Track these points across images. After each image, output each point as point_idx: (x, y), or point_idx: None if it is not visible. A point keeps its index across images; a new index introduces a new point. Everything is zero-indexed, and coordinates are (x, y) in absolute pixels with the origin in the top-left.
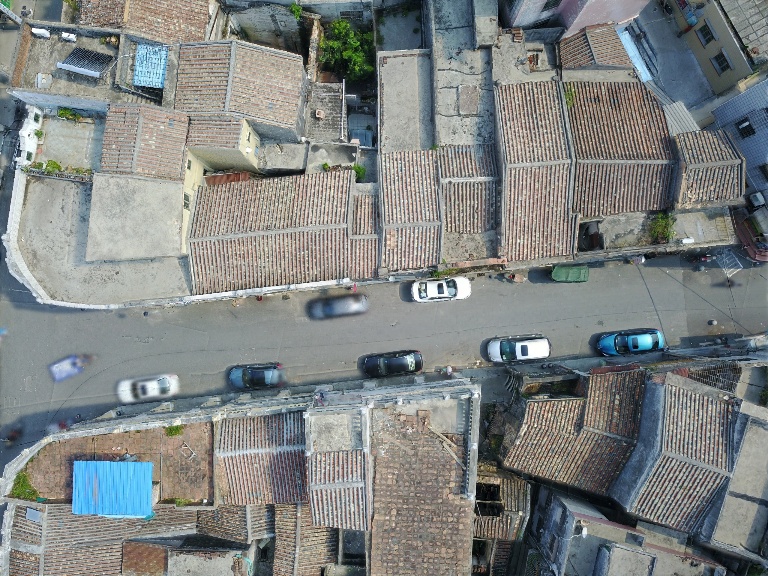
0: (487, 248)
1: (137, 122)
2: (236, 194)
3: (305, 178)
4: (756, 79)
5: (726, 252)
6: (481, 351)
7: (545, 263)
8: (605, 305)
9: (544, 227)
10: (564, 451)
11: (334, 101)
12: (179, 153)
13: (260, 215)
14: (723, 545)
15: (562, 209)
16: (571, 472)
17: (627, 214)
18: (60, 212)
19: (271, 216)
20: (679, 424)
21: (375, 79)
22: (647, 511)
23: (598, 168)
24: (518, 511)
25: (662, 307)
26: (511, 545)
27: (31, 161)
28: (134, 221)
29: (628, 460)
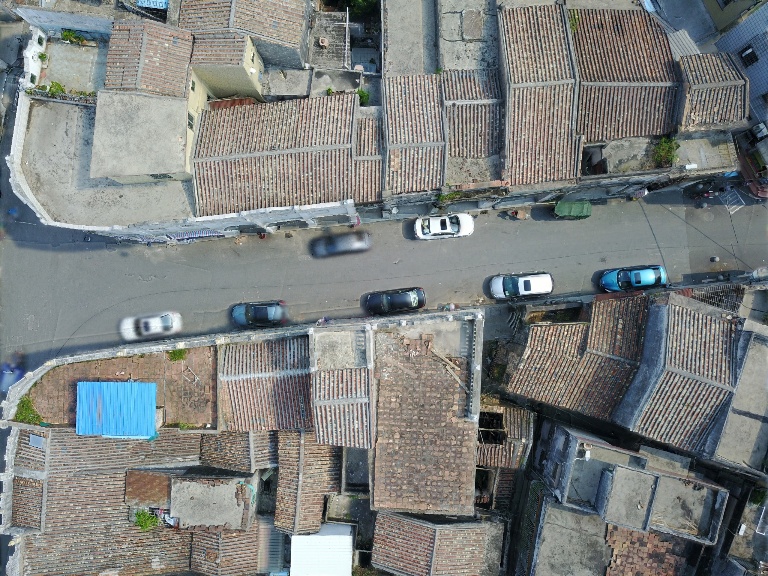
0: (491, 173)
1: (141, 38)
2: (240, 117)
3: (309, 101)
4: None
5: (728, 189)
6: (484, 288)
7: (549, 187)
8: (608, 242)
9: (548, 149)
10: (567, 375)
11: (338, 30)
12: (183, 71)
13: (264, 136)
14: (726, 461)
15: (566, 131)
16: (574, 397)
17: (630, 139)
18: (64, 136)
19: (275, 137)
20: (682, 341)
21: (378, 12)
22: (650, 430)
23: (602, 91)
24: (521, 438)
25: (665, 244)
26: (514, 480)
27: (35, 84)
28: (138, 138)
29: (631, 383)
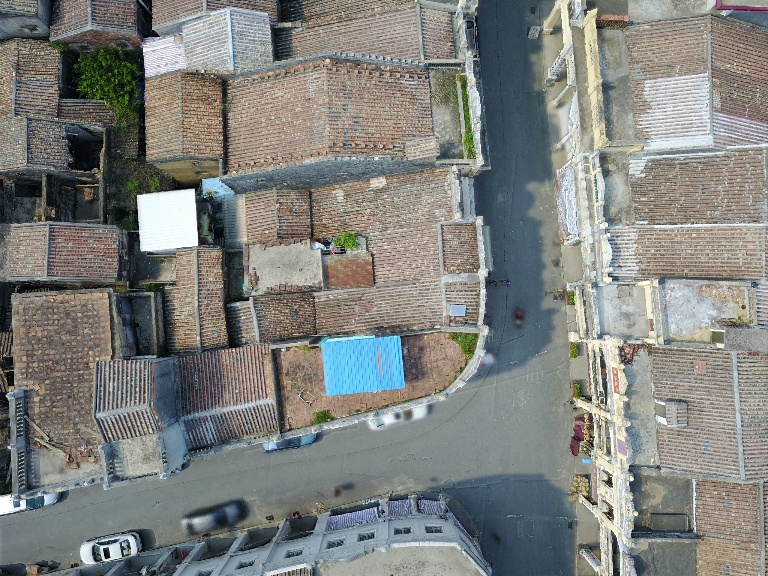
0: None
1: None
2: None
3: None
4: None
5: None
6: None
7: None
8: None
9: None
10: None
11: None
12: None
13: None
14: None
15: None
16: None
17: None
18: None
19: None
20: None
21: None
22: None
23: None
24: None
25: None
26: None
27: None
28: None
29: None
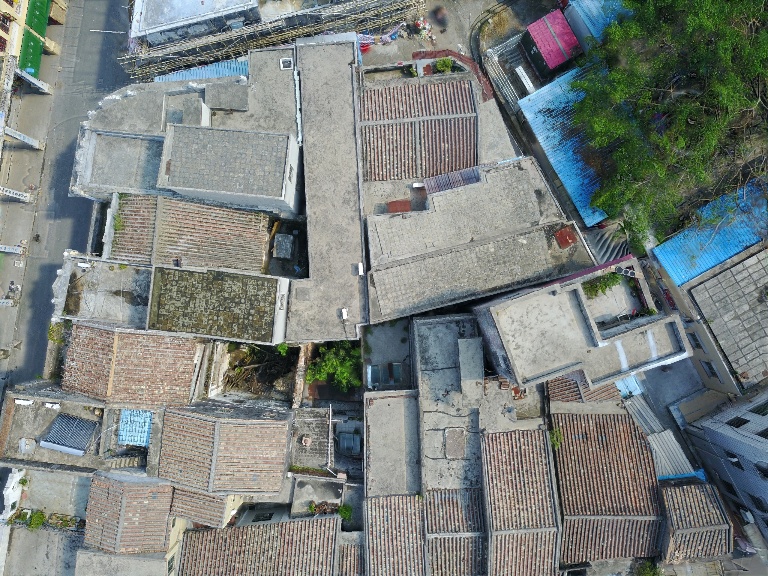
0: None
1: (120, 501)
2: (221, 544)
3: (291, 527)
4: (746, 396)
5: None
6: None
7: None
8: None
9: None
10: None
11: (321, 426)
12: (163, 524)
13: (245, 573)
14: None
15: (549, 568)
16: None
17: None
18: (45, 558)
19: (256, 574)
20: None
21: None
22: None
23: (585, 522)
24: None
25: None
26: None
27: (15, 508)
28: None
29: None
